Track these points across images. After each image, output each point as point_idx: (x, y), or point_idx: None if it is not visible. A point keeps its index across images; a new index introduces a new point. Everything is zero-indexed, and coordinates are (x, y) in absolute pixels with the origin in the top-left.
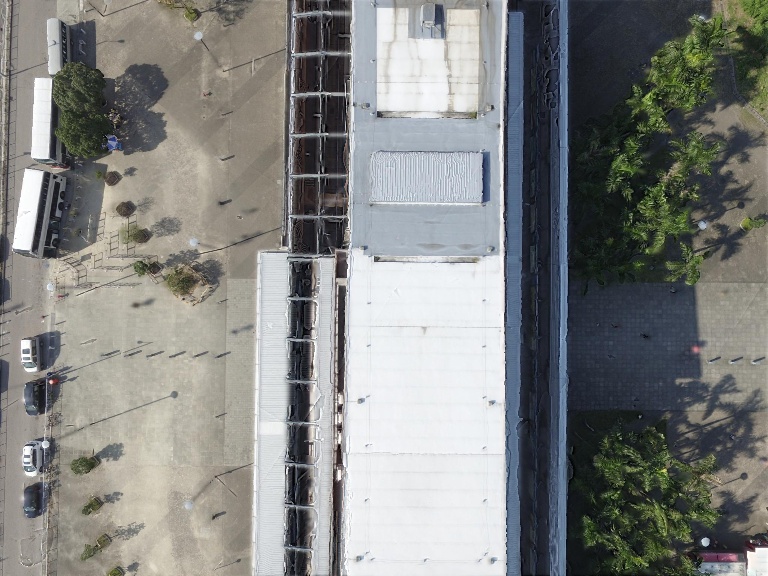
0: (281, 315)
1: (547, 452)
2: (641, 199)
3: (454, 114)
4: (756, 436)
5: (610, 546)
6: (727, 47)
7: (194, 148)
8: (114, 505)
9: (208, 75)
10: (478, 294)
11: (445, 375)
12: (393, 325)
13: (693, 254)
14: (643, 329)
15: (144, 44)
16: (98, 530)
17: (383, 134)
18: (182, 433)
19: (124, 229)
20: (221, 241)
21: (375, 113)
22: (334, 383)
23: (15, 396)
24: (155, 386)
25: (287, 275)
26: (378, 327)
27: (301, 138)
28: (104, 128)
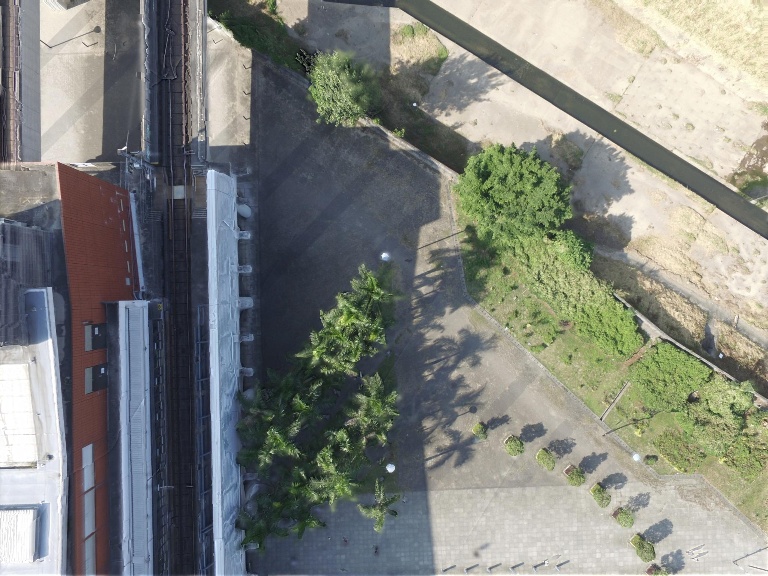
0: None
1: None
2: (321, 449)
3: (17, 462)
4: None
5: None
6: (456, 247)
7: None
8: None
9: None
10: None
11: None
12: None
13: (425, 462)
14: (376, 540)
15: None
16: None
17: None
18: None
19: None
20: None
21: None
22: None
23: None
24: None
25: None
26: None
27: None
28: None
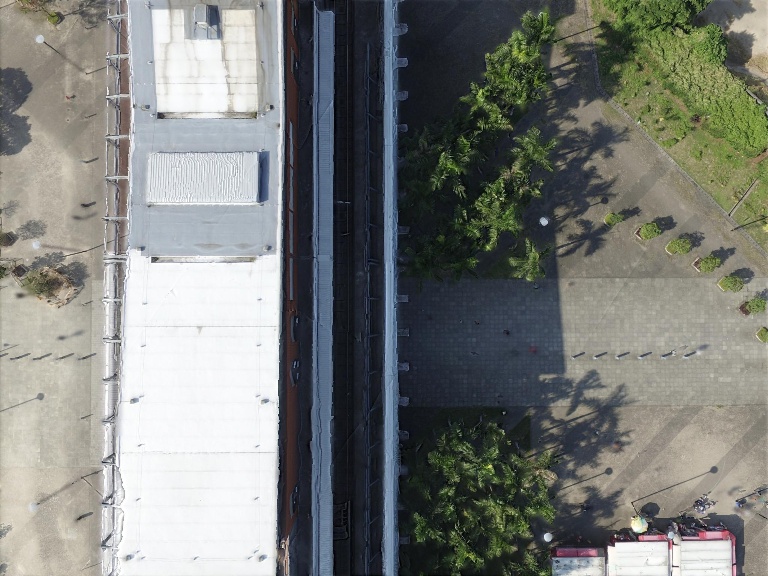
0: None
1: (383, 449)
2: (479, 196)
3: (236, 114)
4: (621, 431)
5: (442, 542)
6: (590, 42)
7: (58, 151)
8: None
9: (72, 78)
10: (253, 293)
11: (219, 374)
12: (169, 325)
13: (556, 250)
14: (507, 325)
15: (8, 48)
16: None
17: (163, 135)
18: (49, 435)
19: None
20: (86, 243)
21: (155, 114)
22: None
23: None
24: (22, 388)
25: (113, 276)
26: (152, 327)
27: None
28: None
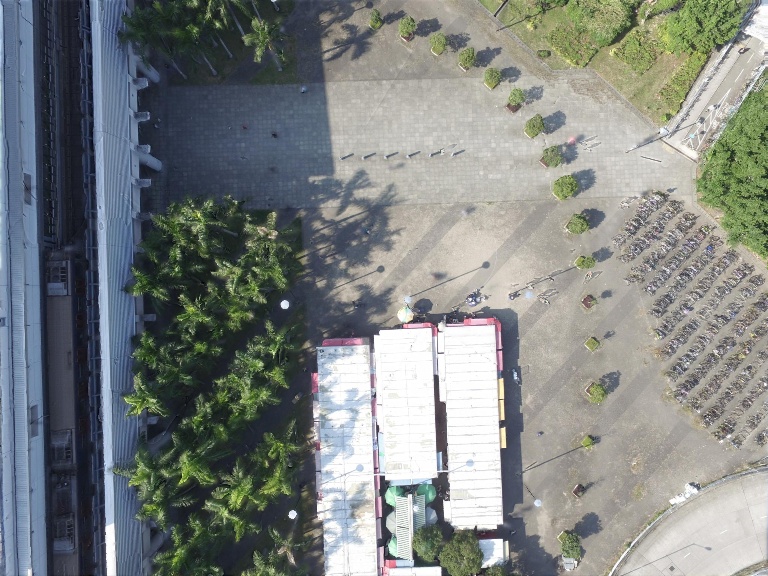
0: None
1: None
2: None
3: None
4: (391, 229)
5: (164, 300)
6: None
7: None
8: None
9: None
10: None
11: None
12: None
13: (323, 55)
14: (275, 130)
15: None
16: None
17: None
18: None
19: None
20: None
21: None
22: None
23: None
24: None
25: None
26: None
27: None
28: None
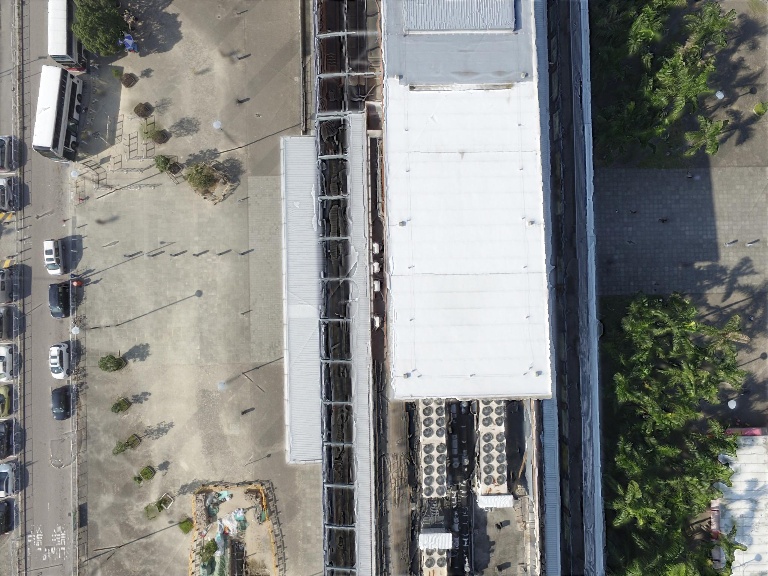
0: (306, 200)
1: (575, 317)
2: (660, 68)
3: None
4: None
5: (641, 404)
6: None
7: (210, 48)
8: (142, 405)
9: None
10: (514, 119)
11: (484, 197)
12: (431, 151)
13: None
14: (661, 214)
15: None
16: (127, 431)
17: None
18: (208, 331)
19: (143, 130)
20: (240, 139)
21: None
22: (368, 234)
23: (39, 300)
24: (179, 286)
25: (315, 142)
26: (416, 152)
27: (322, 14)
28: (120, 23)
